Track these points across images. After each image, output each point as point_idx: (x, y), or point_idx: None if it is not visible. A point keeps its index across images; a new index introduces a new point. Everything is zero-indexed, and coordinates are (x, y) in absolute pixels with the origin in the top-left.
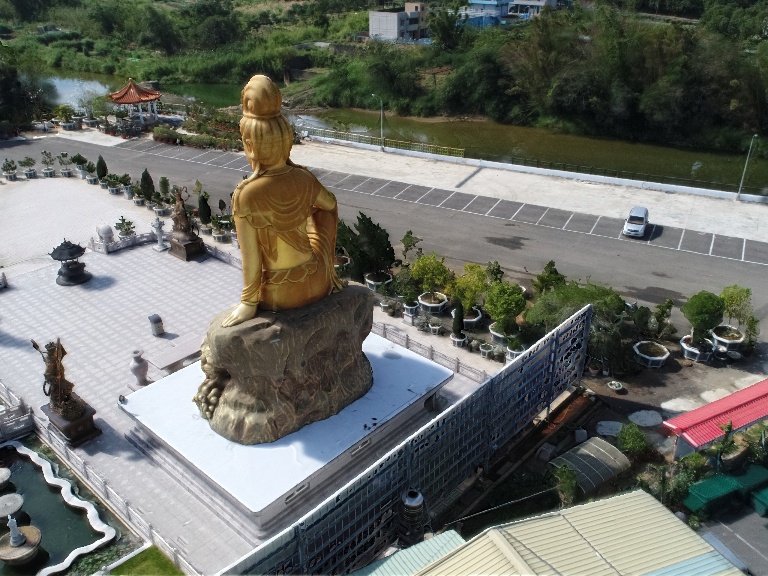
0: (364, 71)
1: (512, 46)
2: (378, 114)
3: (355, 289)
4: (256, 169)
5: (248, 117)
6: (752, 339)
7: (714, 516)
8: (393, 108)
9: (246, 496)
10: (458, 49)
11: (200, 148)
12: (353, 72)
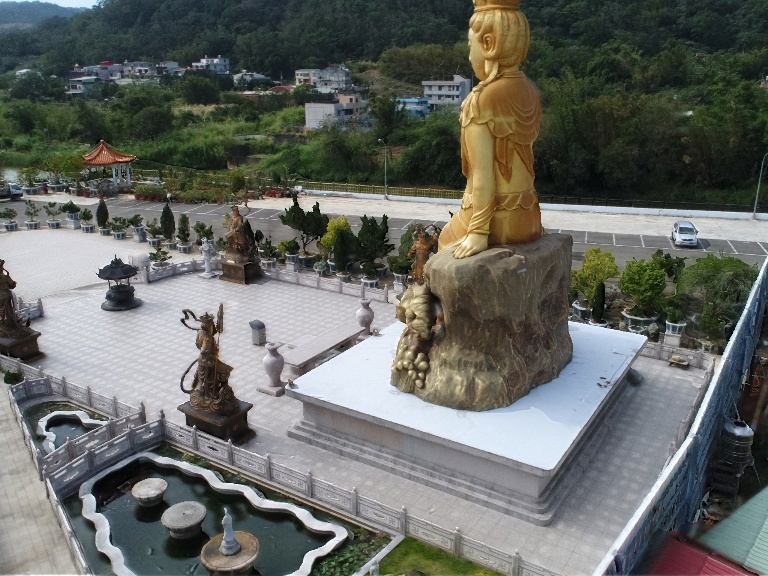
0: (320, 148)
1: None
2: None
3: None
4: (493, 70)
5: (487, 10)
6: None
7: None
8: None
9: (524, 456)
10: (411, 126)
11: (191, 203)
12: (304, 153)
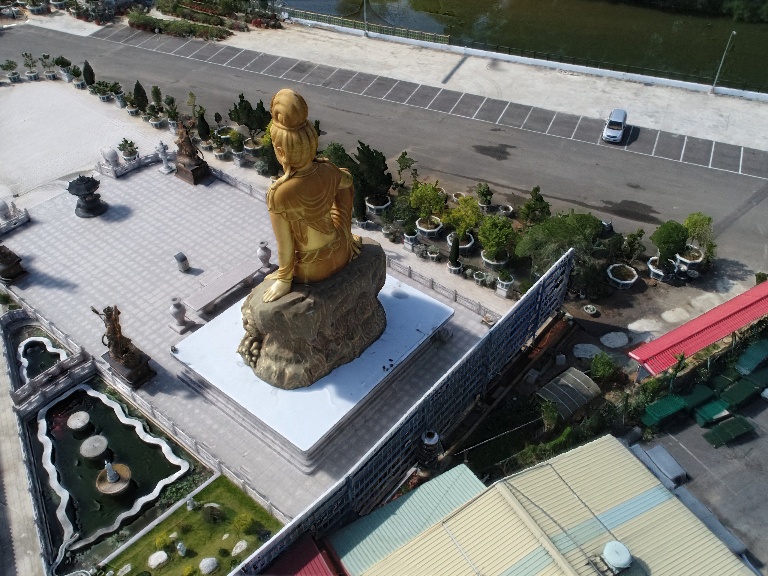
0: None
1: None
2: None
3: (370, 250)
4: (287, 171)
5: (278, 127)
6: (709, 260)
7: (664, 428)
8: None
9: (295, 437)
10: None
11: (180, 36)
12: None
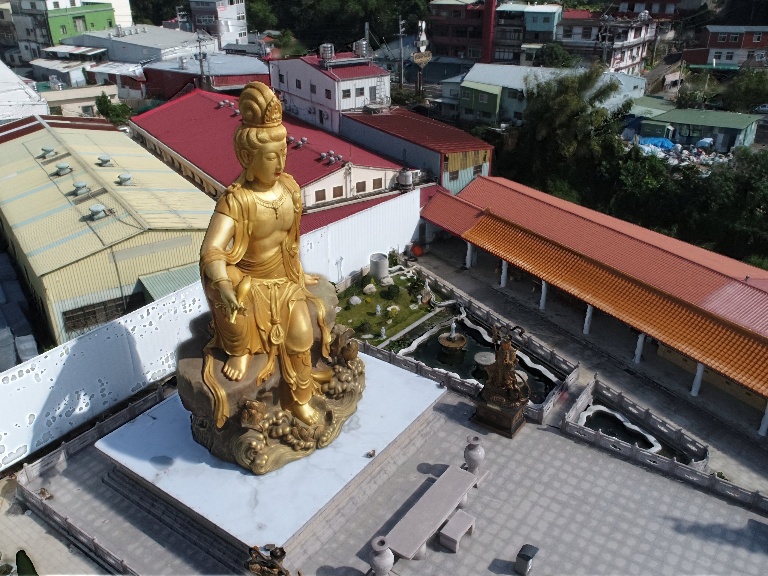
0: None
1: None
2: None
3: (196, 344)
4: None
5: None
6: None
7: None
8: None
9: None
10: None
11: None
12: None
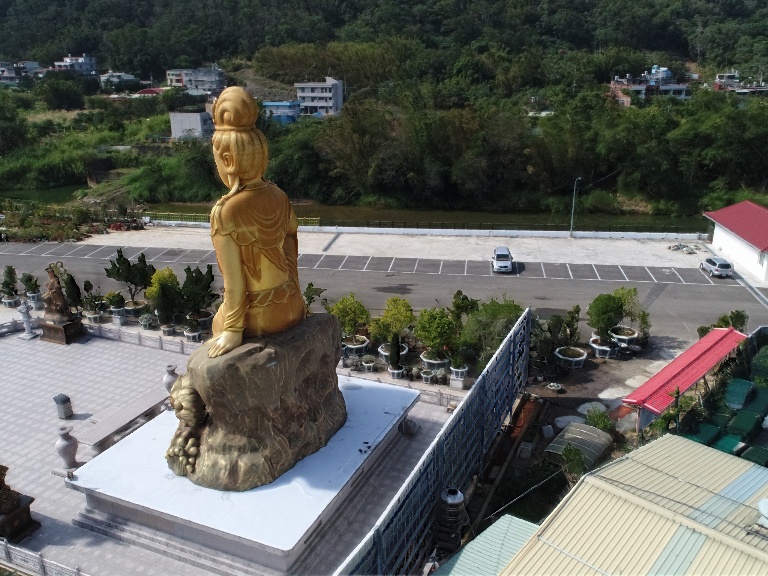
0: (181, 165)
1: (327, 133)
2: (201, 206)
3: None
4: (235, 184)
5: (224, 130)
6: (646, 332)
7: None
8: (216, 199)
9: (269, 538)
10: (273, 139)
11: (30, 242)
12: (167, 168)
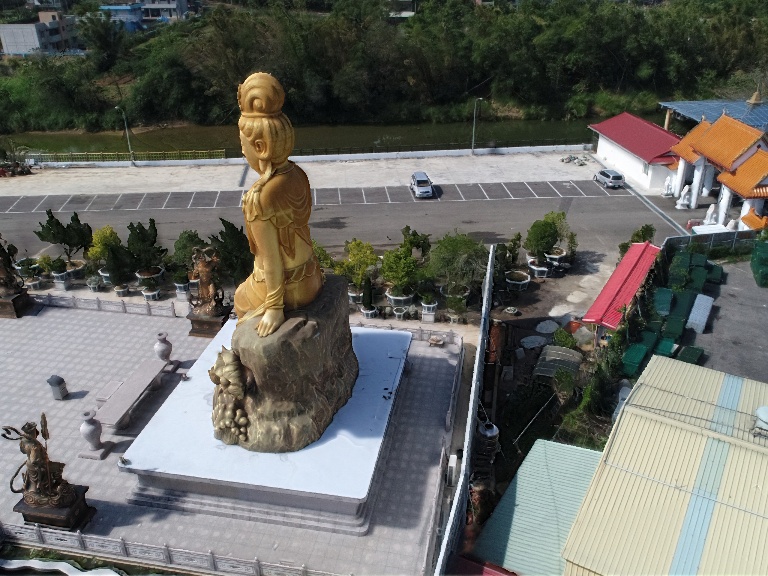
0: (34, 89)
1: (197, 47)
2: (63, 134)
3: None
4: (268, 169)
5: (254, 117)
6: (574, 250)
7: None
8: (81, 125)
9: (342, 490)
10: (135, 56)
11: None
12: (13, 92)
